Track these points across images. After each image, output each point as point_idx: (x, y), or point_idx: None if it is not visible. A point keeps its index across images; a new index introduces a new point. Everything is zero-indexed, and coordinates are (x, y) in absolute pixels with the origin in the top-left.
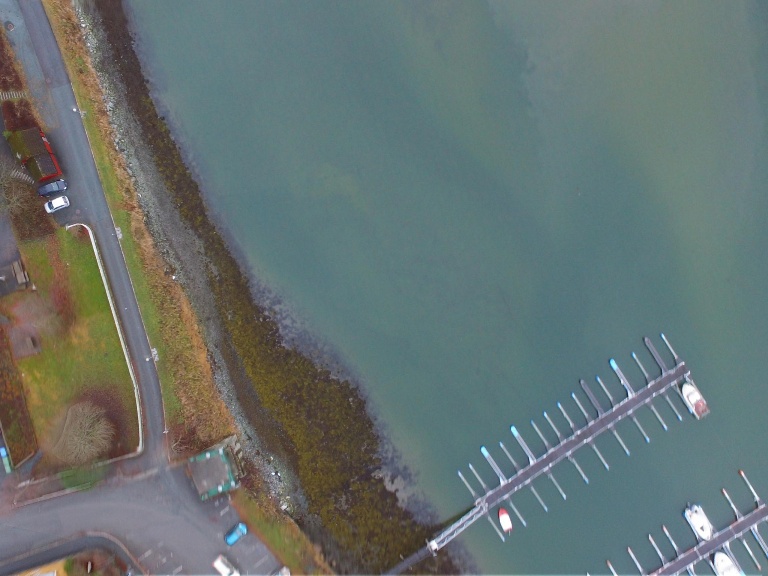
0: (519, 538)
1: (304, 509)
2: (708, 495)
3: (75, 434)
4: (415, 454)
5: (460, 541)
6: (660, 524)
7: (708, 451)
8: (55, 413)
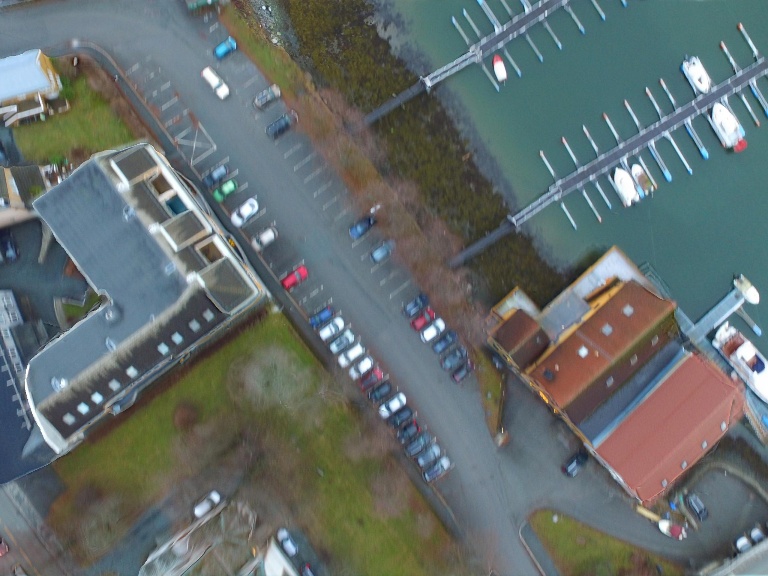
0: (514, 88)
1: (295, 49)
2: (706, 48)
3: None
4: (408, 2)
5: (454, 91)
6: (657, 77)
7: (706, 3)
8: None
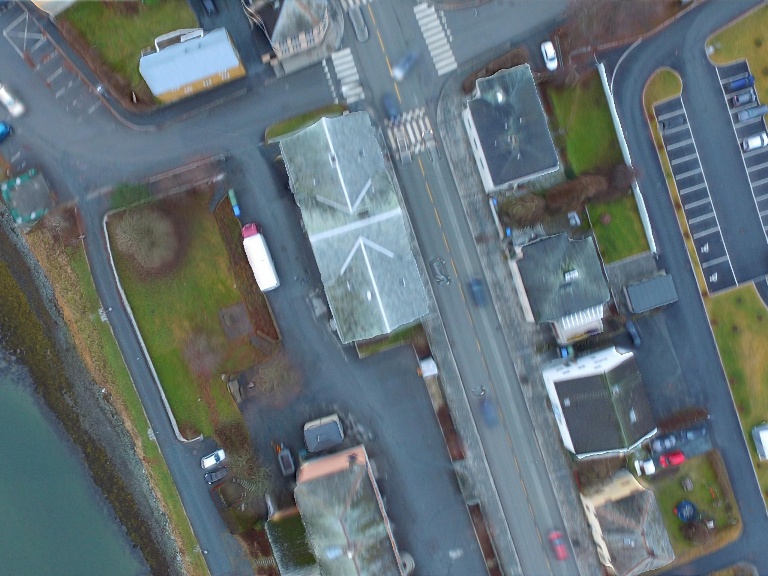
0: None
1: None
2: None
3: (139, 240)
4: None
5: None
6: None
7: None
8: (202, 249)
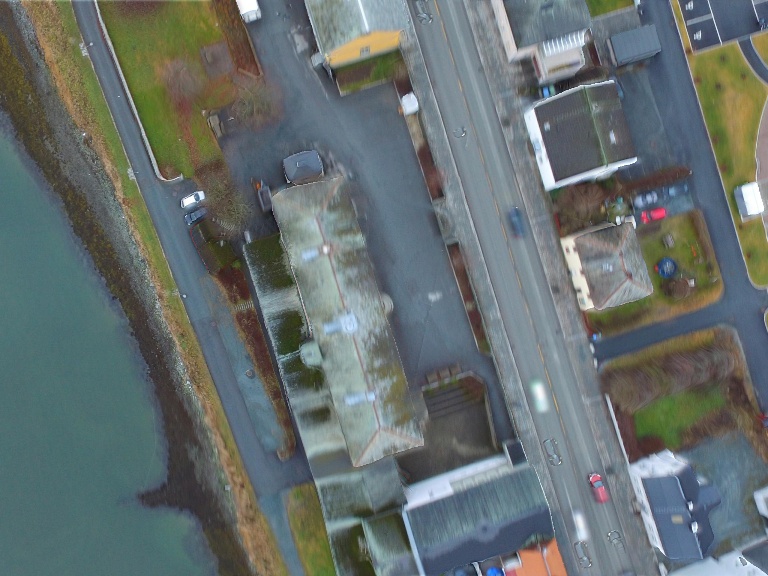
0: None
1: None
2: None
3: None
4: None
5: None
6: None
7: None
8: None
